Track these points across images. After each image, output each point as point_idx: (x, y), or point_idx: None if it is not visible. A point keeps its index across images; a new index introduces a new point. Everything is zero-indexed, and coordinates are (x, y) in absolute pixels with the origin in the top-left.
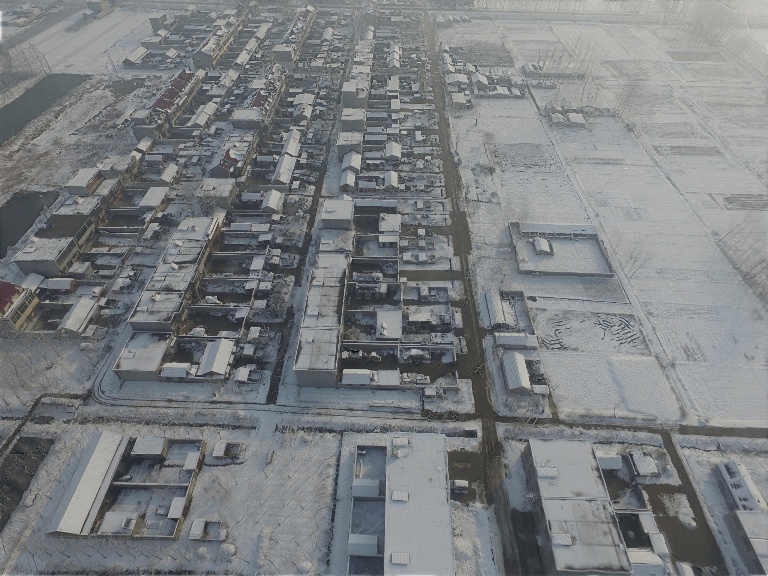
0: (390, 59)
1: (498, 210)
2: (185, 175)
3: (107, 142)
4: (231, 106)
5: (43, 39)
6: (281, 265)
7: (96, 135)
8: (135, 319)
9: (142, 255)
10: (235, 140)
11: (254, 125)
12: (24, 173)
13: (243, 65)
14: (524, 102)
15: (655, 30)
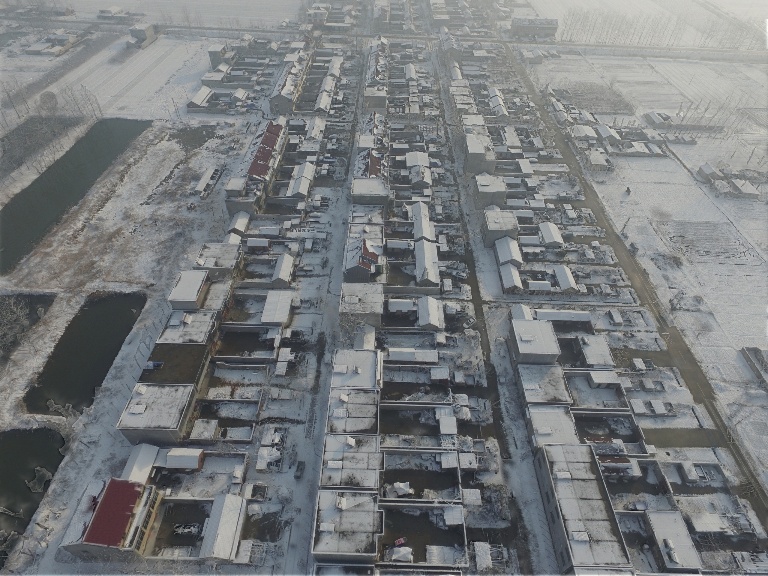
0: (495, 105)
1: (714, 324)
2: (302, 268)
3: (190, 216)
4: (330, 166)
5: (85, 73)
6: (474, 420)
7: (174, 205)
8: (322, 548)
9: (280, 402)
10: (363, 223)
11: (380, 201)
12: (96, 263)
13: (327, 110)
14: (669, 162)
15: (767, 70)
